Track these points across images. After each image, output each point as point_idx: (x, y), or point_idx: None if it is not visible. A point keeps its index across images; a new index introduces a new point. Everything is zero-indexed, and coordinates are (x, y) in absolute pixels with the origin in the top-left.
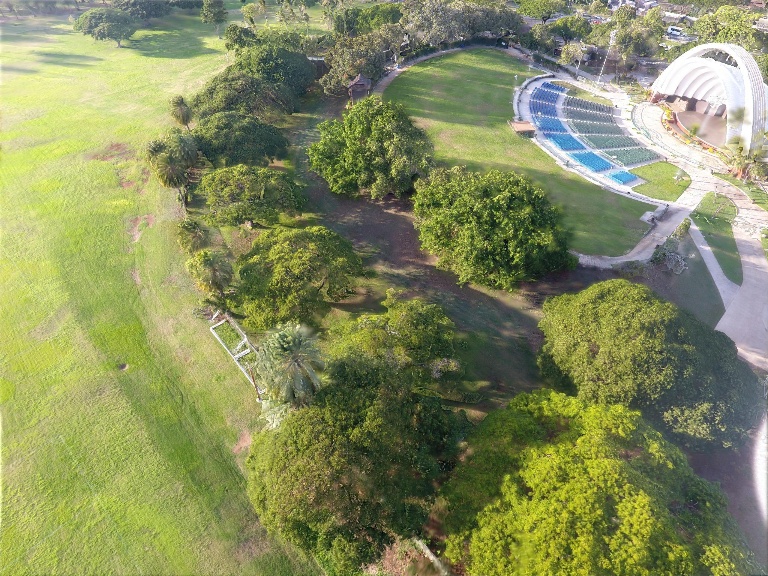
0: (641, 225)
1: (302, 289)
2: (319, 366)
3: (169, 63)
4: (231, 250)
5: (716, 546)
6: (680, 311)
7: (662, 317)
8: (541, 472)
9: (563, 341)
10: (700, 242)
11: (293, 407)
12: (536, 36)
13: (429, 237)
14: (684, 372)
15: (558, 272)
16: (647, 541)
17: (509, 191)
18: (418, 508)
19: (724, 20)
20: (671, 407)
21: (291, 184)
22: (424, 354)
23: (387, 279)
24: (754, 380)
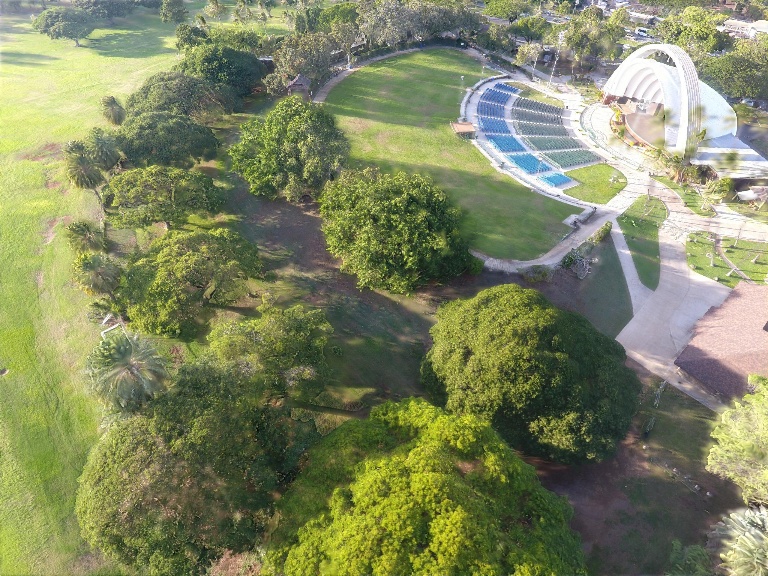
0: (562, 228)
1: (183, 293)
2: (156, 374)
3: (124, 62)
4: (142, 252)
5: (527, 565)
6: (570, 317)
7: (537, 324)
8: (364, 486)
9: (440, 348)
10: (621, 246)
11: (122, 417)
12: (492, 36)
13: (332, 240)
14: (552, 381)
15: (464, 276)
16: (454, 560)
17: (408, 194)
18: (247, 522)
19: (688, 21)
20: (538, 417)
21: (208, 185)
22: (286, 361)
23: (294, 283)
24: (637, 388)
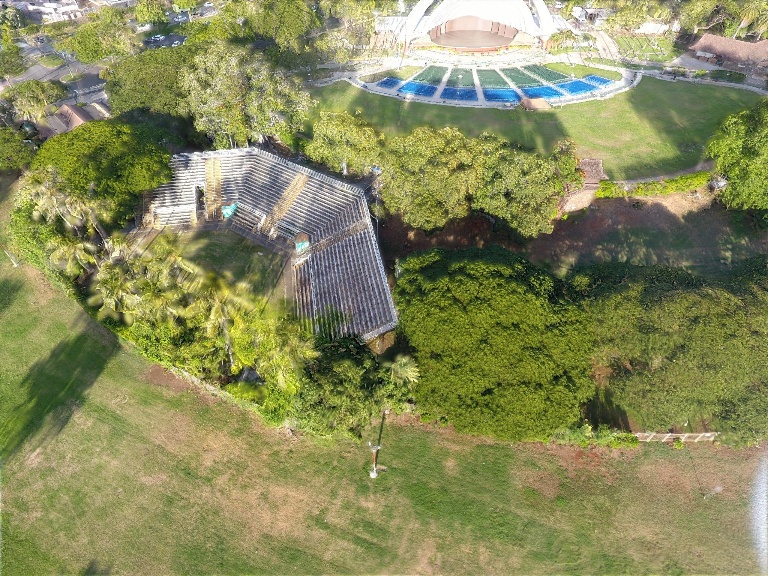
0: (685, 82)
1: None
2: None
3: None
4: None
5: None
6: None
7: None
8: None
9: None
10: None
11: None
12: (297, 51)
13: None
14: None
15: None
16: None
17: None
18: None
19: None
20: None
21: None
22: None
23: None
24: None
